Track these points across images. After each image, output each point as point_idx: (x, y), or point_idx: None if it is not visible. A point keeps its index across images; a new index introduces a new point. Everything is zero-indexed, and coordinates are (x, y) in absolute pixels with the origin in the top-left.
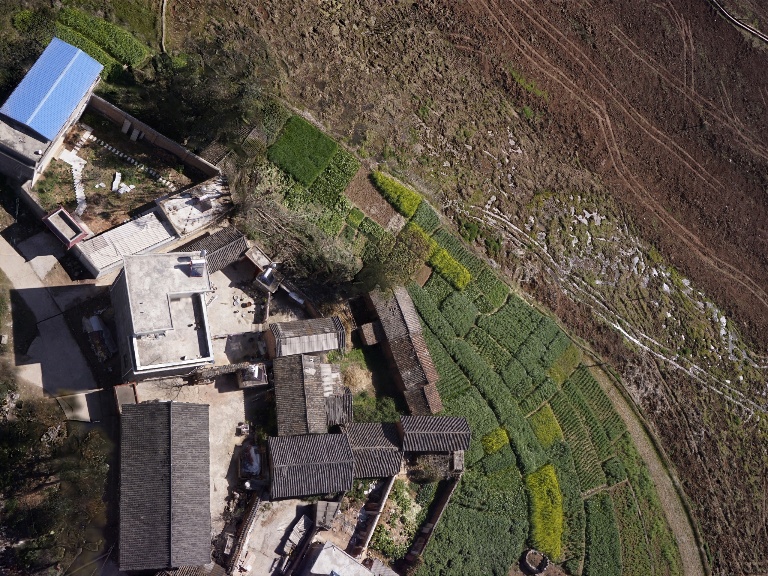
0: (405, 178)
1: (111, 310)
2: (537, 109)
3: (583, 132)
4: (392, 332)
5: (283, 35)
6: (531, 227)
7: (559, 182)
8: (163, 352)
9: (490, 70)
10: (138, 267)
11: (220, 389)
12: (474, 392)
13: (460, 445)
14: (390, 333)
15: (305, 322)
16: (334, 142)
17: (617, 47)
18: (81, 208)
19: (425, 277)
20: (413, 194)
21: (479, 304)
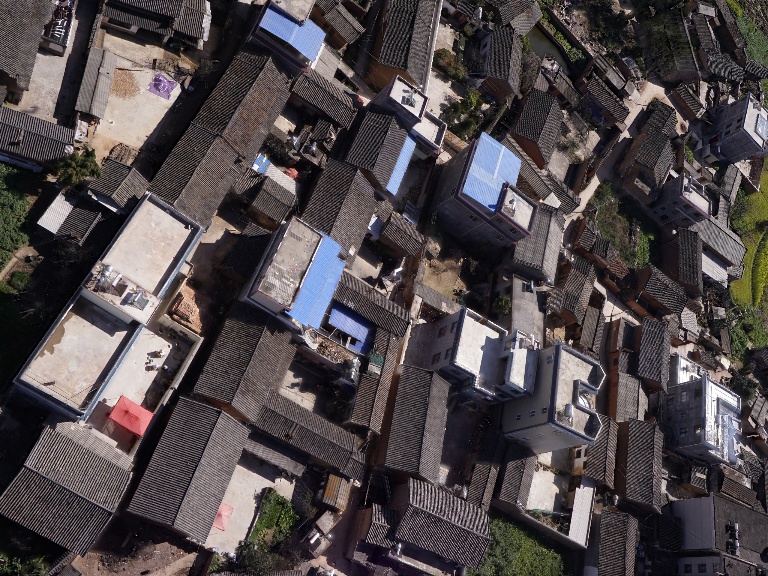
0: None
1: None
2: None
3: None
4: (728, 20)
5: None
6: (754, 1)
7: None
8: None
9: None
10: None
11: None
12: None
13: (764, 76)
14: (727, 20)
15: None
16: None
17: None
18: None
19: None
20: None
21: None
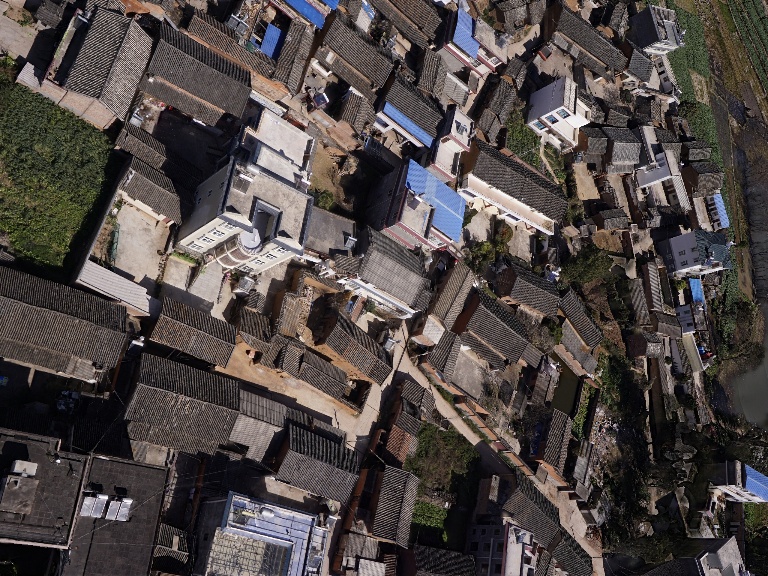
0: None
1: None
2: None
3: None
4: None
5: None
6: None
7: None
8: None
9: None
10: (734, 545)
11: None
12: None
13: None
14: None
15: None
16: None
17: None
18: None
19: None
20: None
21: None
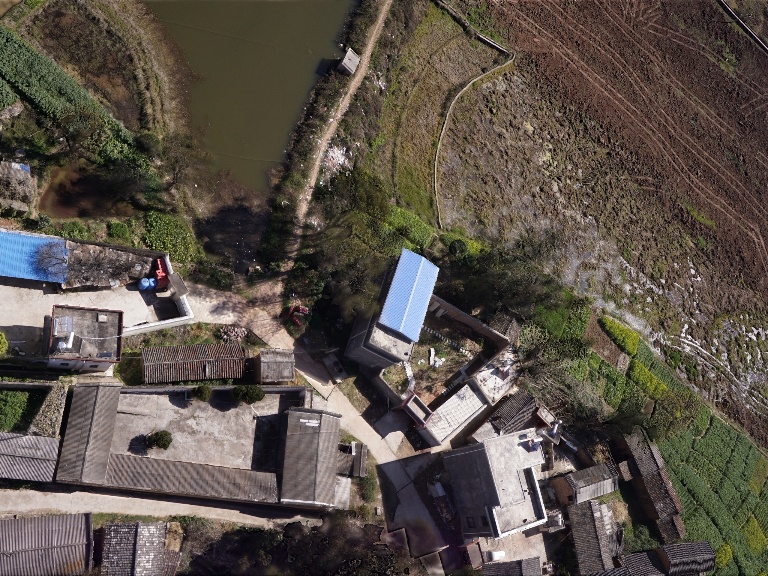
0: (622, 318)
1: (447, 475)
2: (708, 238)
3: (745, 255)
4: (645, 469)
5: (519, 198)
6: (716, 349)
7: (731, 304)
8: (510, 517)
9: (670, 206)
10: (494, 449)
11: (526, 534)
12: (702, 512)
13: (708, 567)
14: (644, 470)
15: (588, 470)
16: (571, 294)
17: (763, 172)
18: (412, 385)
19: (650, 409)
20: (634, 334)
21: (692, 429)
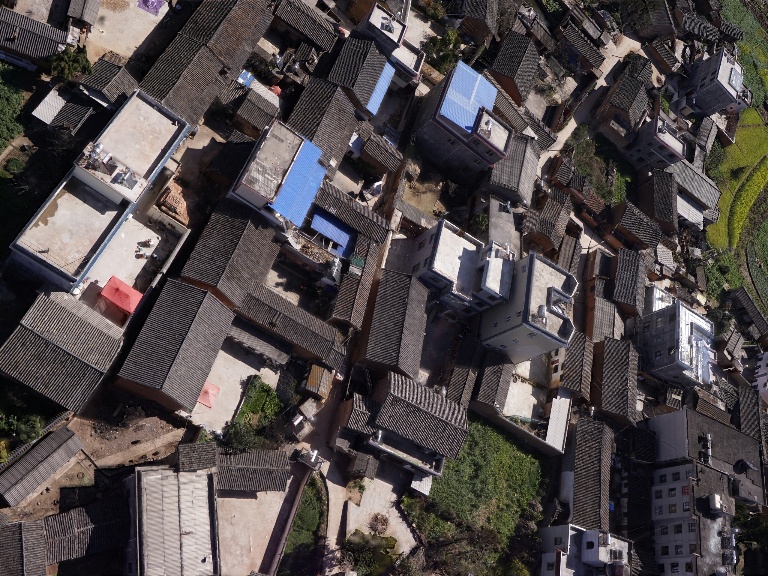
0: None
1: None
2: None
3: None
4: None
5: None
6: None
7: None
8: None
9: None
10: None
11: None
12: None
13: (739, 36)
14: None
15: None
16: None
17: None
18: None
19: None
20: None
21: None
